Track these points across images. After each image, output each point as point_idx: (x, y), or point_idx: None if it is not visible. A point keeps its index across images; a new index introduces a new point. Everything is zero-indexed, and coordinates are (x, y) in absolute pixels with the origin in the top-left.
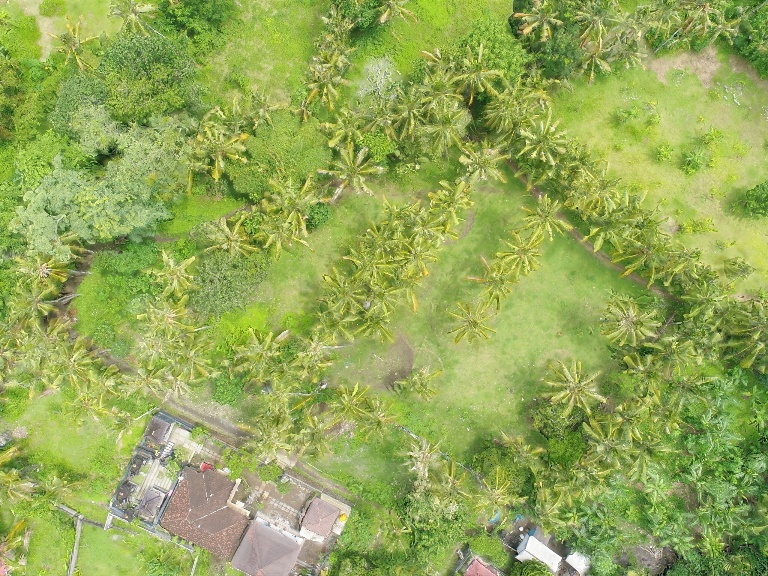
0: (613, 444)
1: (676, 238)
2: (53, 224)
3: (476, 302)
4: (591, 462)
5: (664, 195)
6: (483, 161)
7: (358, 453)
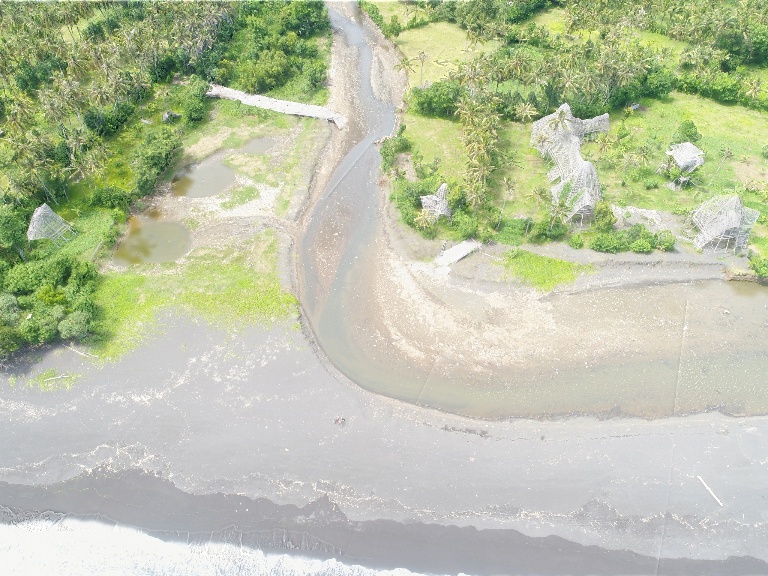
0: None
1: None
2: None
3: None
4: None
5: None
6: None
7: None
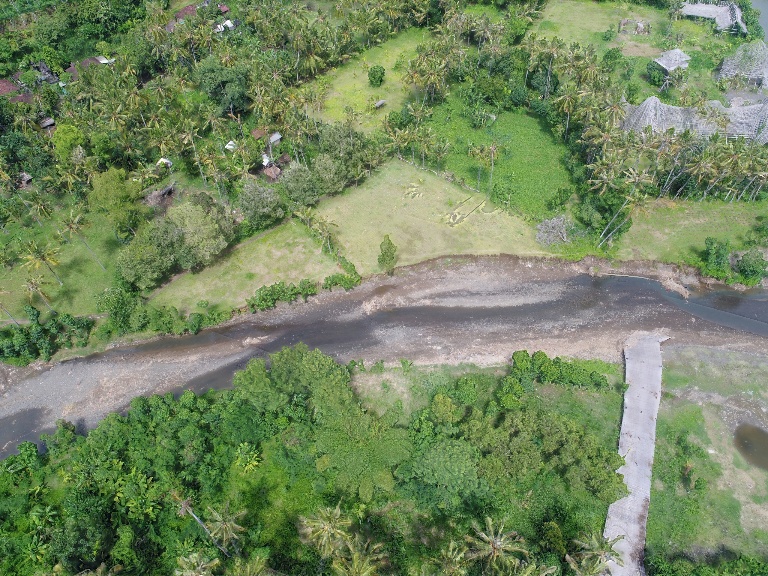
0: (271, 7)
1: None
2: None
3: None
4: None
5: (382, 63)
6: None
7: None
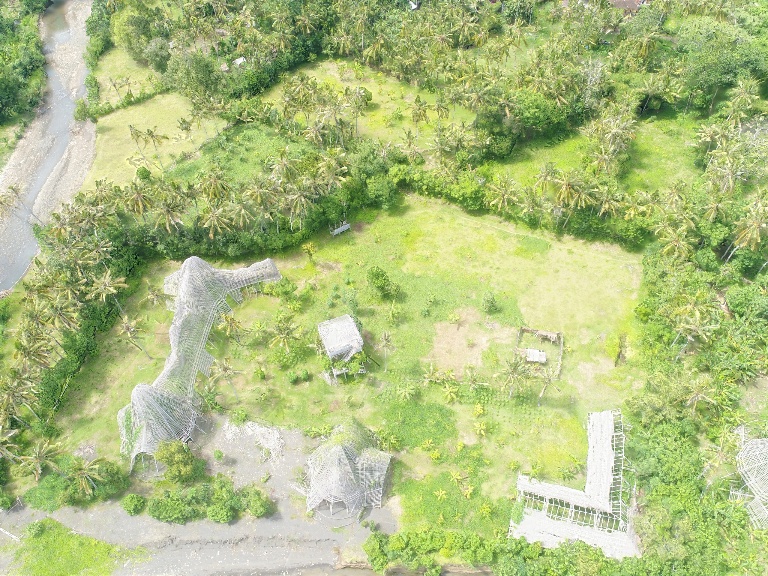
0: None
1: (404, 95)
2: (736, 15)
3: (508, 71)
4: (458, 4)
5: None
6: (525, 69)
7: (556, 31)
